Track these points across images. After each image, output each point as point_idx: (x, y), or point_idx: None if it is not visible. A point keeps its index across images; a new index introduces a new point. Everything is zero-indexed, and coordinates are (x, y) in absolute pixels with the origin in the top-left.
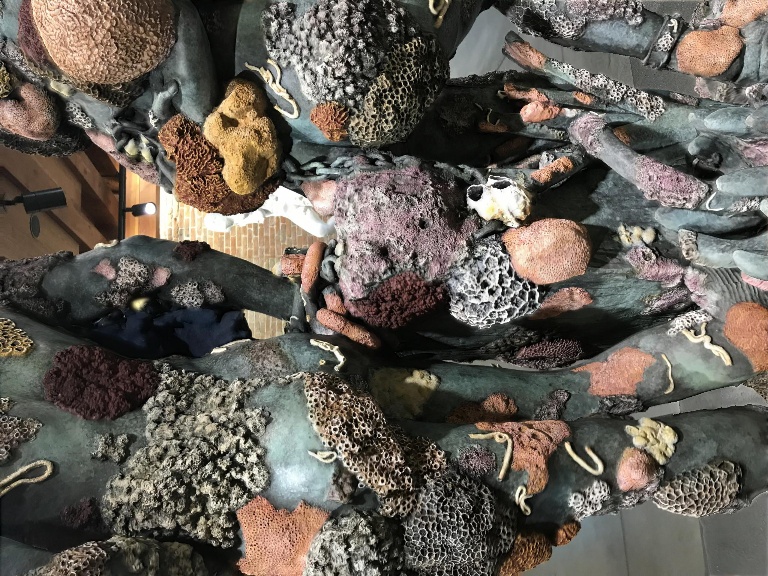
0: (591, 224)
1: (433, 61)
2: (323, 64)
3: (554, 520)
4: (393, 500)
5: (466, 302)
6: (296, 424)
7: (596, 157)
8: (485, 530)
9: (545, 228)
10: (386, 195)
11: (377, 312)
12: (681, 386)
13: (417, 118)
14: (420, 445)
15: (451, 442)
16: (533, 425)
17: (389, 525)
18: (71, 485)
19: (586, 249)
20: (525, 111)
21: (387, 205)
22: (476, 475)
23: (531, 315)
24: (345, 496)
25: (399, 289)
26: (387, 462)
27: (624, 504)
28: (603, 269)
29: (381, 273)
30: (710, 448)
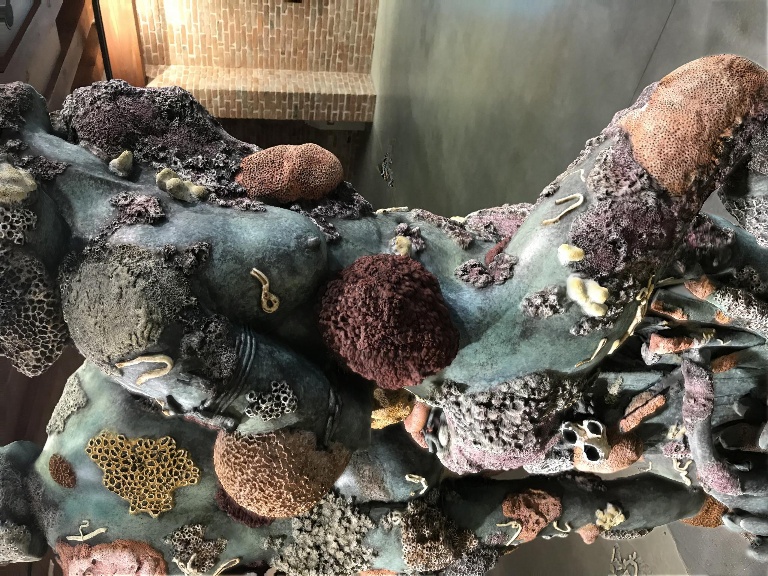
0: (652, 422)
1: None
2: (479, 446)
3: None
4: None
5: None
6: (394, 559)
7: None
8: None
9: (610, 462)
10: None
11: None
12: None
13: None
14: (465, 537)
15: (484, 531)
16: (539, 506)
17: (435, 574)
18: (250, 560)
19: None
20: (655, 350)
21: (493, 452)
22: None
23: None
24: (415, 574)
25: None
26: None
27: None
28: None
29: None
30: (641, 524)
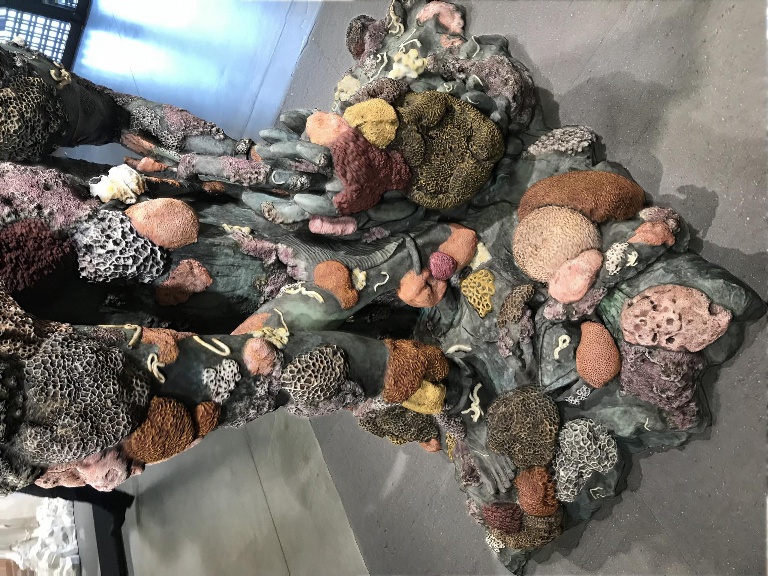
0: (200, 222)
1: (55, 102)
2: None
3: (191, 395)
4: (11, 342)
5: (93, 255)
6: None
7: (195, 172)
8: (115, 369)
9: None
10: (11, 165)
11: (2, 266)
12: (293, 329)
13: (42, 136)
14: (44, 321)
15: None
16: None
17: (6, 357)
18: None
19: (194, 217)
20: None
21: (12, 172)
22: (105, 341)
23: (161, 297)
24: None
25: (24, 234)
26: (5, 309)
27: (257, 393)
28: (212, 240)
29: (5, 216)
30: (316, 339)
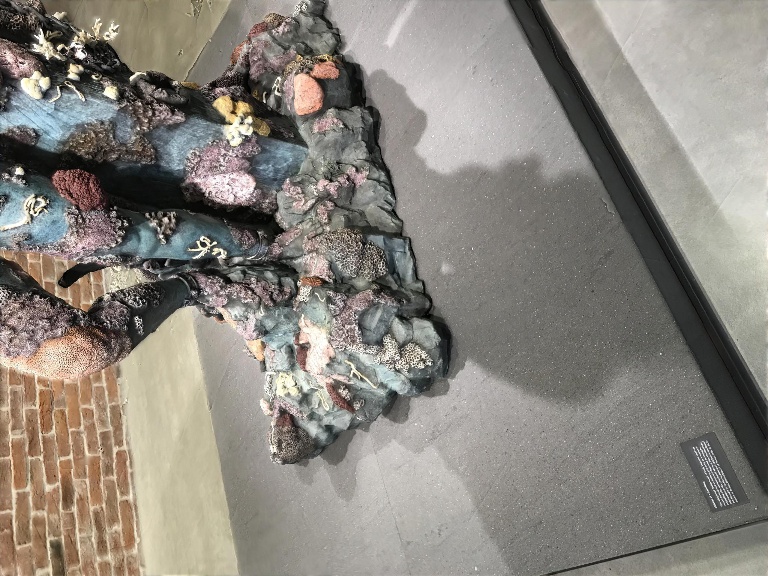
0: None
1: None
2: None
3: None
4: None
5: None
6: None
7: None
8: None
9: None
10: None
11: None
12: None
13: None
14: None
15: None
16: None
17: None
18: None
19: None
20: None
21: None
22: None
23: None
24: None
25: None
26: None
27: None
28: None
29: None
30: None
